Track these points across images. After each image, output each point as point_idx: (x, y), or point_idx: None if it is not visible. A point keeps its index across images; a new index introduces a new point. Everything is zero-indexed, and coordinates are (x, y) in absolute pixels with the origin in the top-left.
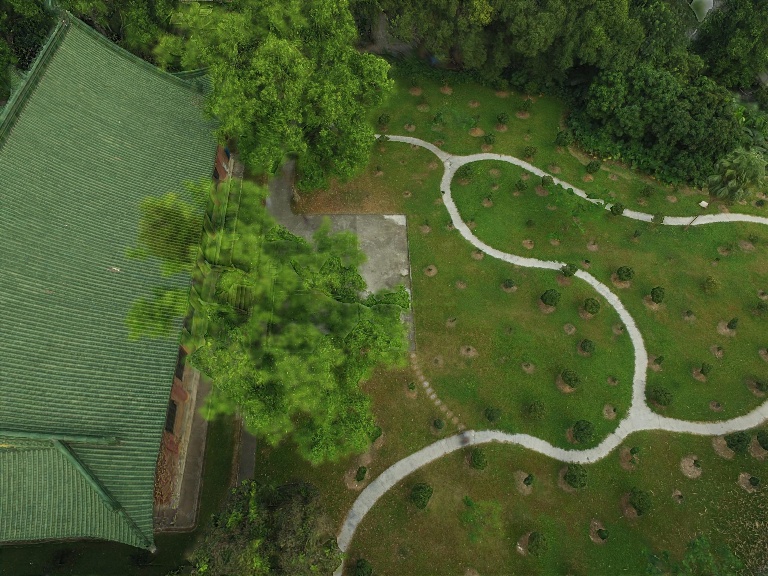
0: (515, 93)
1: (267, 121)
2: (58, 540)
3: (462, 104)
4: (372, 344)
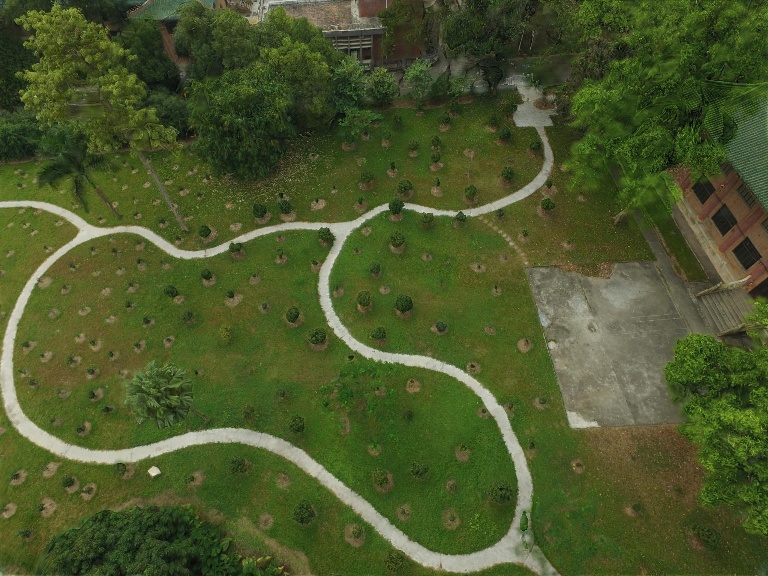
0: None
1: None
2: None
3: None
4: None
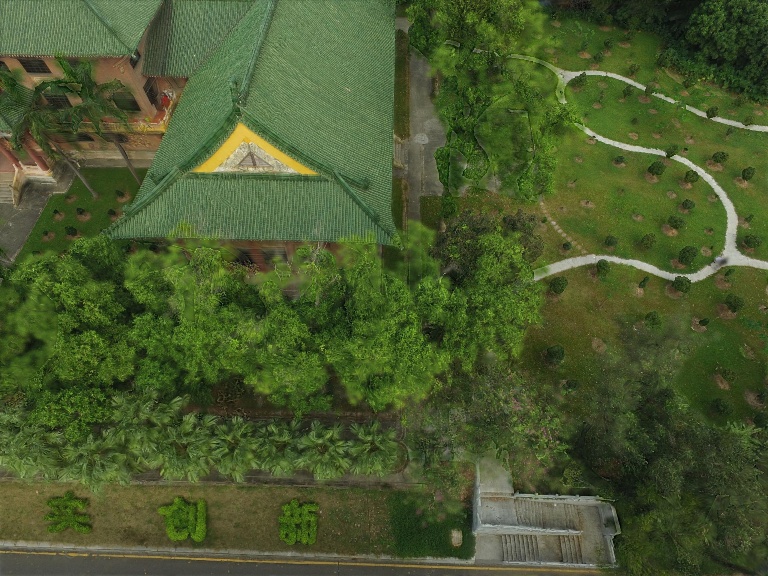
0: (617, 28)
1: (449, 1)
2: (285, 291)
3: (570, 34)
4: (565, 118)
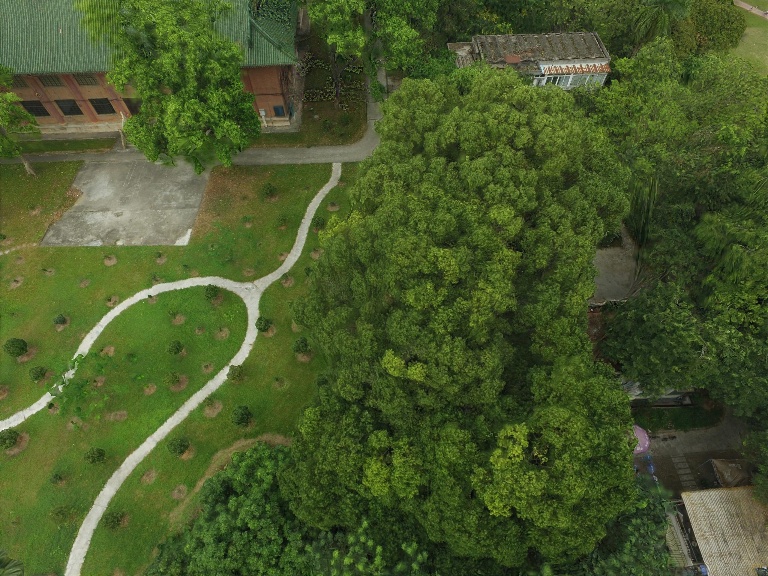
0: None
1: None
2: None
3: None
4: None
